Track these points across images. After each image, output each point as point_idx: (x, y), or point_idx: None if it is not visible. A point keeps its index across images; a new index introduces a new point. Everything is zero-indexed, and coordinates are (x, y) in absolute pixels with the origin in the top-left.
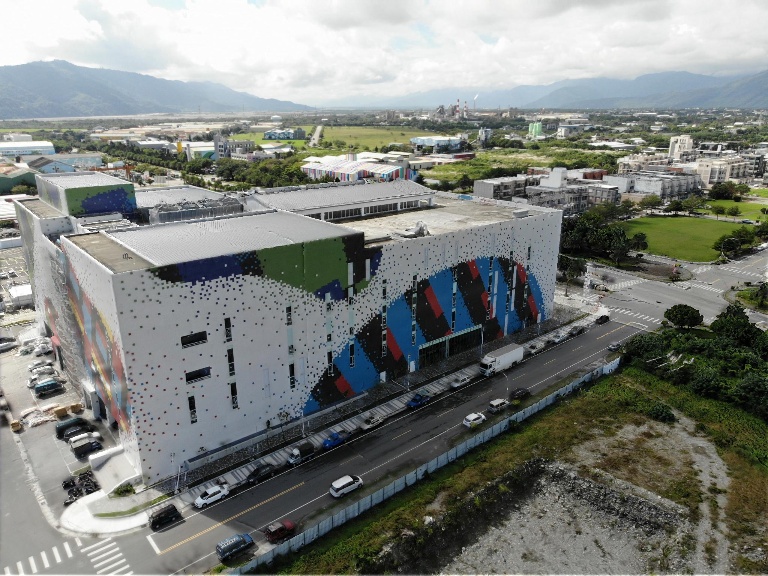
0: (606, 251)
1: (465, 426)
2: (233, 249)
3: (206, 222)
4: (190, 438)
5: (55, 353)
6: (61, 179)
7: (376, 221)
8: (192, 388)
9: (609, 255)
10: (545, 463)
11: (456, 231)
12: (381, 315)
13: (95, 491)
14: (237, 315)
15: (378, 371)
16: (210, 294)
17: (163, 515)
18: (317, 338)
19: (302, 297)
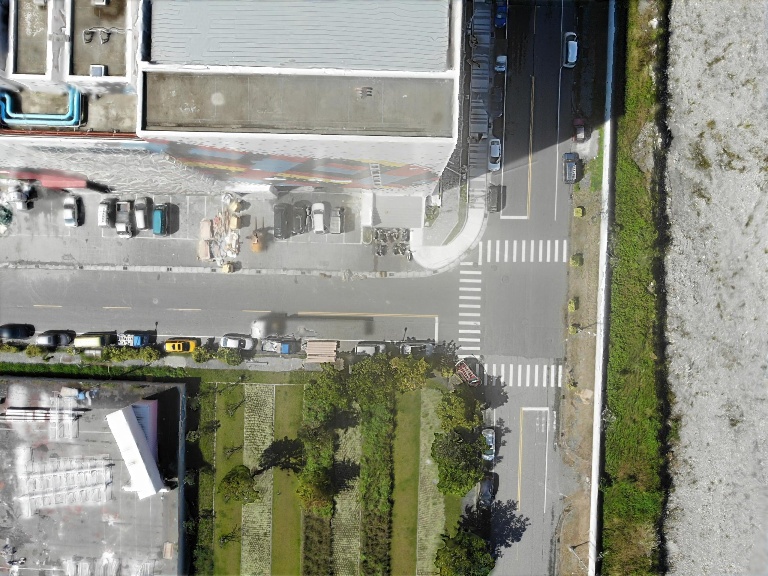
0: None
1: None
2: None
3: None
4: None
5: (61, 190)
6: None
7: None
8: None
9: None
10: None
11: None
12: None
13: (409, 234)
14: None
15: None
16: None
17: None
18: None
19: None
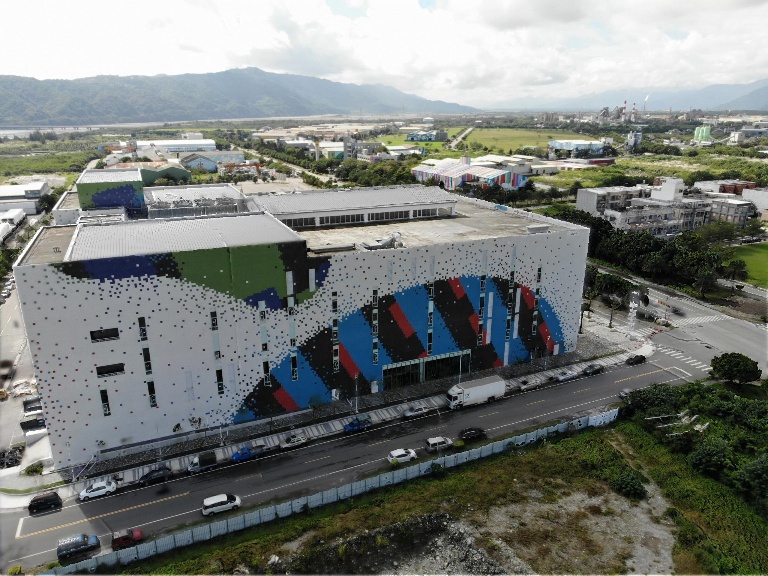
0: (694, 278)
1: (388, 461)
2: (159, 249)
3: (185, 221)
4: (104, 430)
5: None
6: (100, 174)
7: (371, 229)
8: (104, 382)
9: (693, 283)
10: (448, 520)
11: (431, 245)
12: (331, 329)
13: (14, 466)
14: (153, 315)
15: (329, 387)
16: (121, 292)
17: (43, 501)
18: (250, 346)
19: (230, 303)
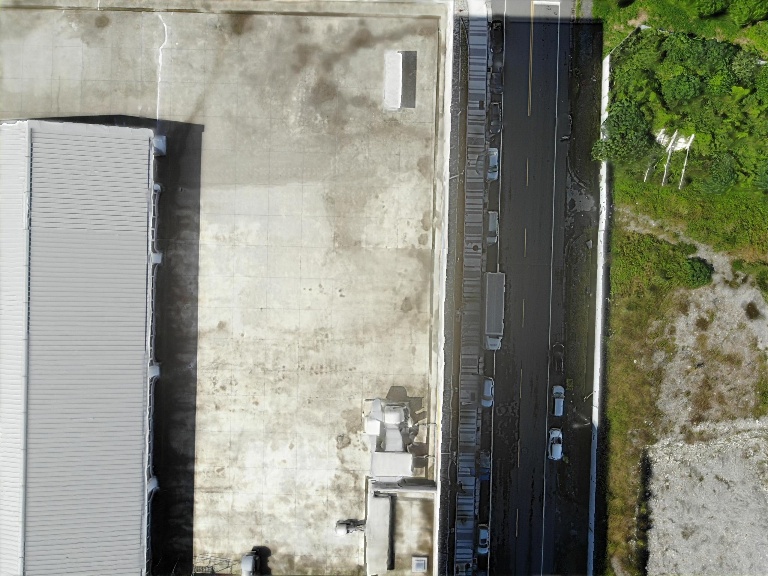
0: None
1: (555, 461)
2: None
3: None
4: None
5: None
6: None
7: (224, 389)
8: None
9: None
10: None
11: None
12: None
13: None
14: None
15: None
16: None
17: None
18: None
19: None
